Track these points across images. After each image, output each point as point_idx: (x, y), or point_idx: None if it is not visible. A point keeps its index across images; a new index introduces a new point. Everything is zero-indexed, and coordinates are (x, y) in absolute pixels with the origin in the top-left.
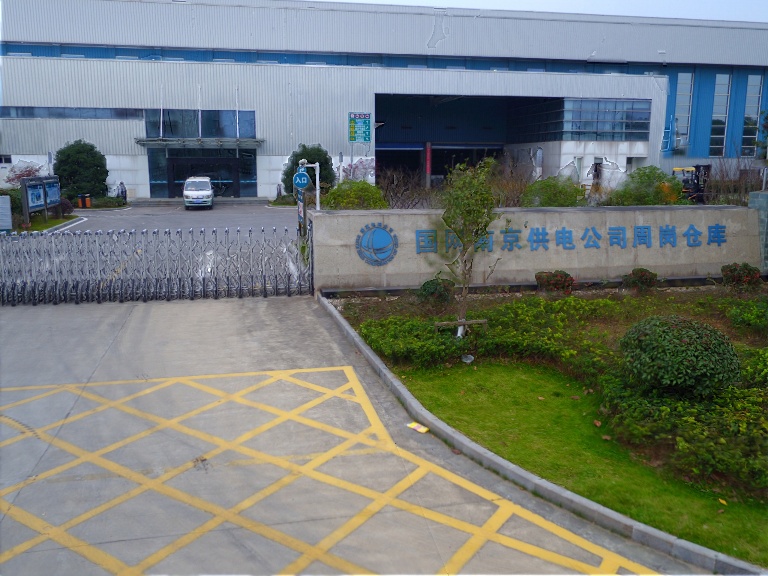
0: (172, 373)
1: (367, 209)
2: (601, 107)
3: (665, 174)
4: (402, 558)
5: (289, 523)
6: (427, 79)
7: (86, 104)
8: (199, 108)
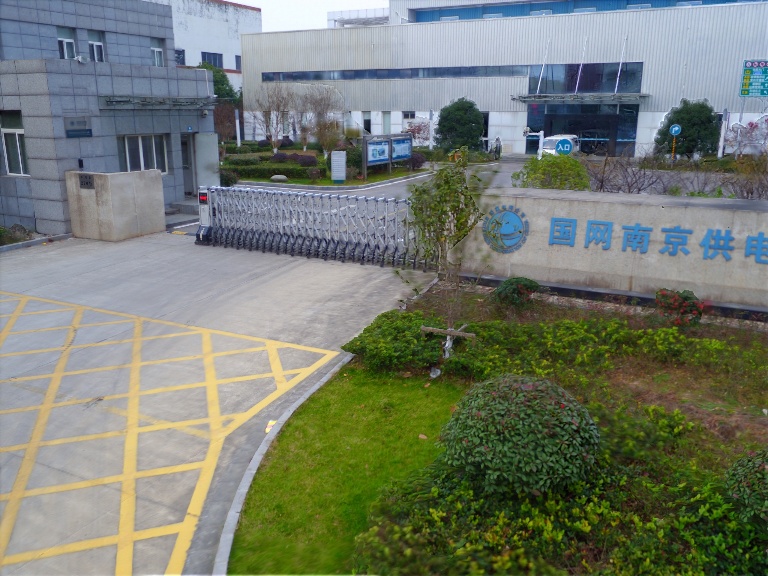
0: (211, 324)
1: (536, 188)
2: None
3: None
4: (46, 526)
5: (48, 467)
6: None
7: (479, 63)
8: (581, 62)
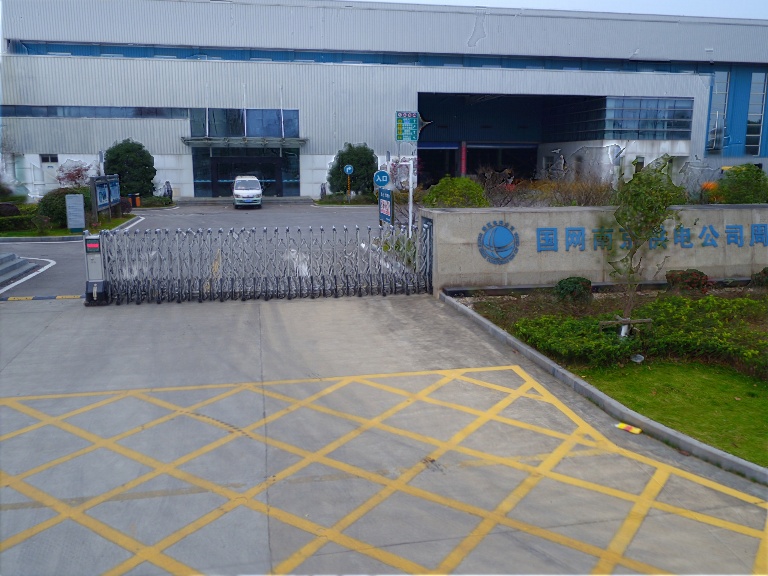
0: (342, 372)
1: (477, 207)
2: (643, 106)
3: (762, 172)
4: (704, 563)
5: (564, 526)
6: (470, 78)
7: (132, 103)
8: (244, 107)
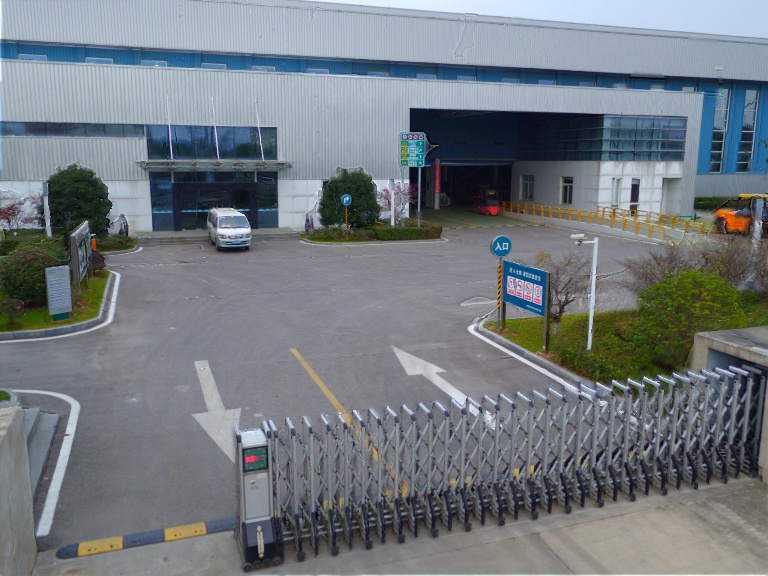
0: None
1: (764, 325)
2: (639, 125)
3: None
4: None
5: None
6: (465, 93)
7: (73, 118)
8: (214, 124)
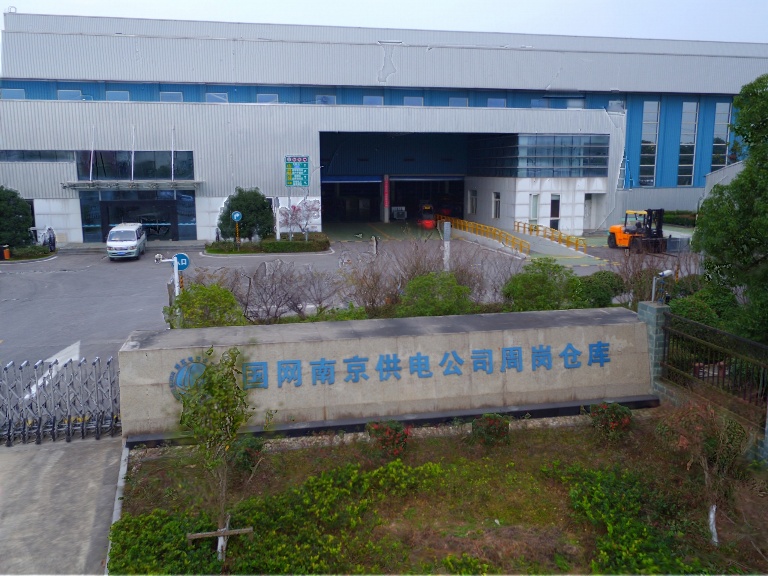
0: None
1: (204, 327)
2: (557, 142)
3: (562, 266)
4: None
5: None
6: (374, 116)
7: (13, 146)
8: (132, 149)
